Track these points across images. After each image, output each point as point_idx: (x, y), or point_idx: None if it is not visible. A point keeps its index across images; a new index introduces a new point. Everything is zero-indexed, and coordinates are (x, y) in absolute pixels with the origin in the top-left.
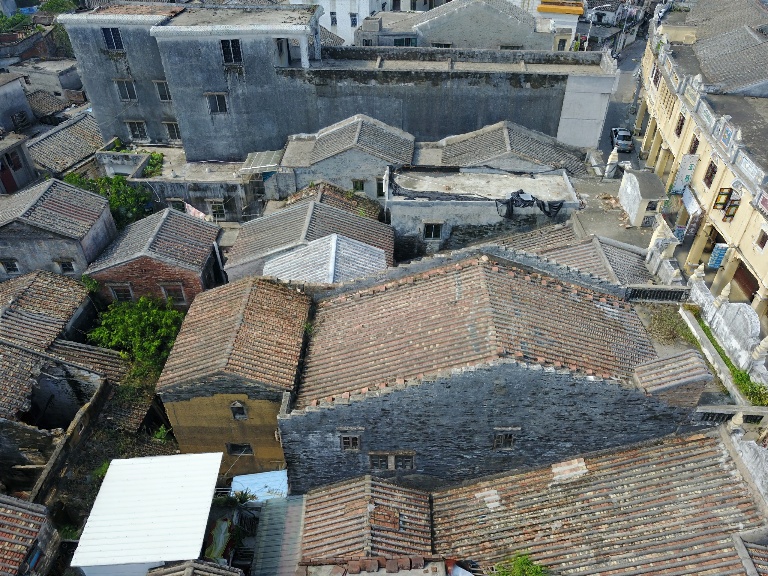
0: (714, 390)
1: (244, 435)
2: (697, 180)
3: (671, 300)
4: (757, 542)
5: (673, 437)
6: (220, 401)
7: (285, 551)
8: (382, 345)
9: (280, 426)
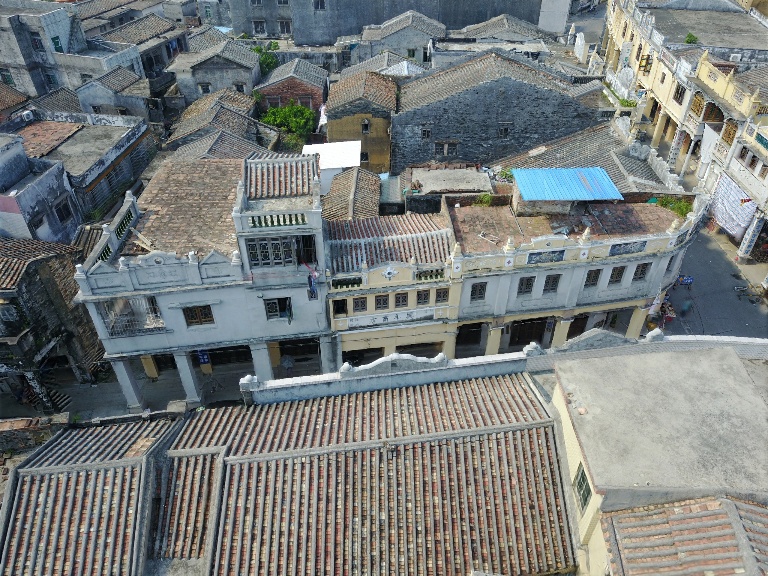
0: None
1: (366, 145)
2: (632, 60)
3: None
4: (621, 154)
5: (589, 129)
6: (357, 119)
7: (392, 192)
8: (441, 92)
9: (392, 121)
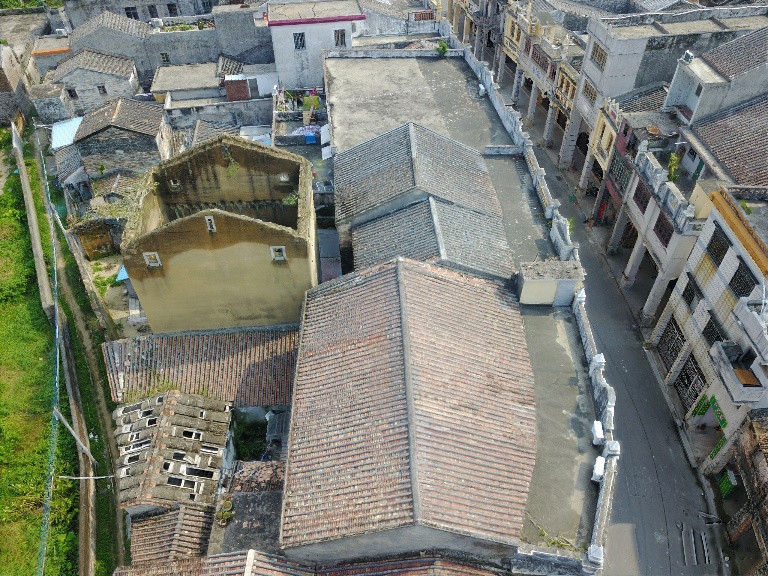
0: None
1: None
2: None
3: None
4: None
5: None
6: None
7: None
8: None
9: None
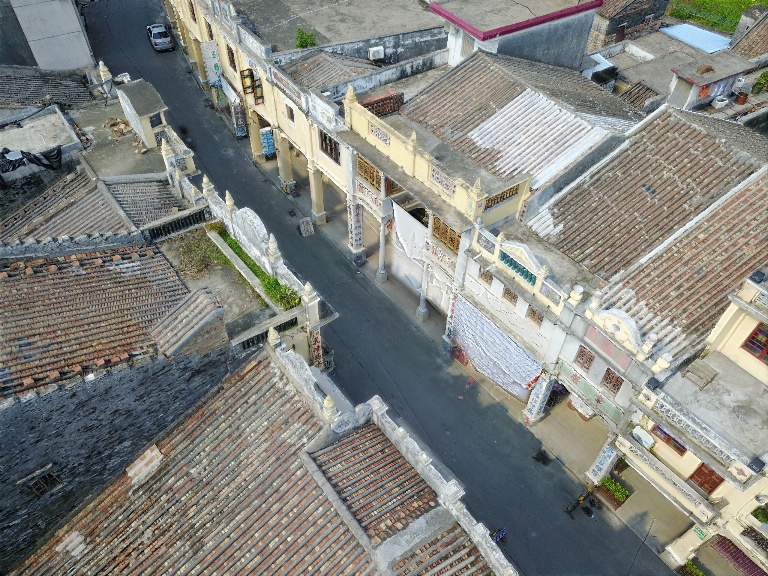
0: (254, 307)
1: None
2: (226, 67)
3: (197, 224)
4: (323, 446)
5: (230, 377)
6: None
7: None
8: None
9: None
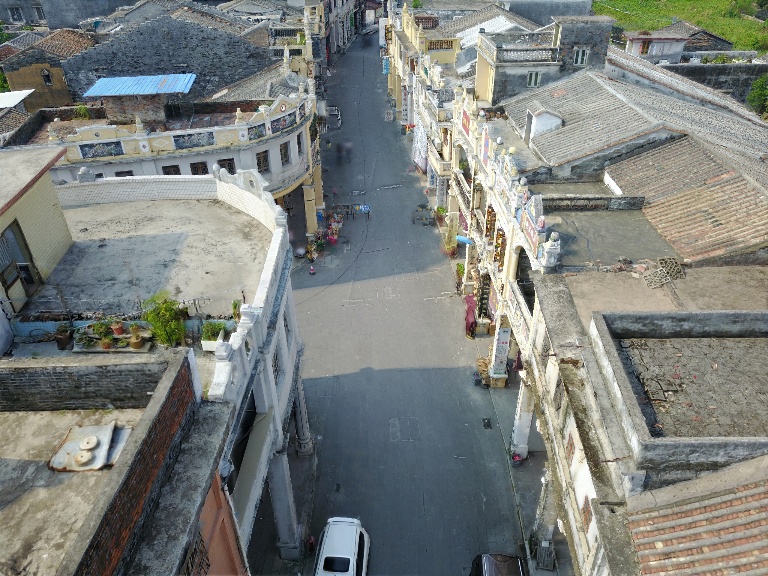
0: None
1: (53, 98)
2: None
3: None
4: (280, 85)
5: (266, 69)
6: (36, 70)
7: None
8: None
9: (63, 67)
